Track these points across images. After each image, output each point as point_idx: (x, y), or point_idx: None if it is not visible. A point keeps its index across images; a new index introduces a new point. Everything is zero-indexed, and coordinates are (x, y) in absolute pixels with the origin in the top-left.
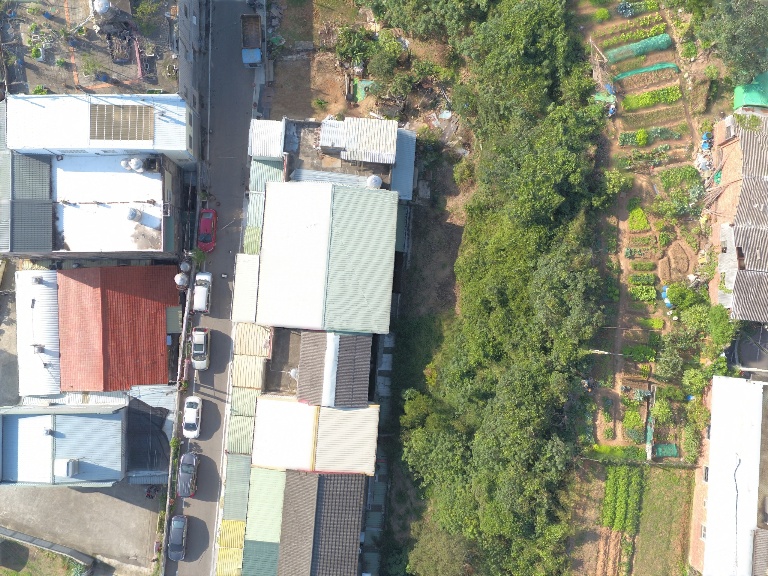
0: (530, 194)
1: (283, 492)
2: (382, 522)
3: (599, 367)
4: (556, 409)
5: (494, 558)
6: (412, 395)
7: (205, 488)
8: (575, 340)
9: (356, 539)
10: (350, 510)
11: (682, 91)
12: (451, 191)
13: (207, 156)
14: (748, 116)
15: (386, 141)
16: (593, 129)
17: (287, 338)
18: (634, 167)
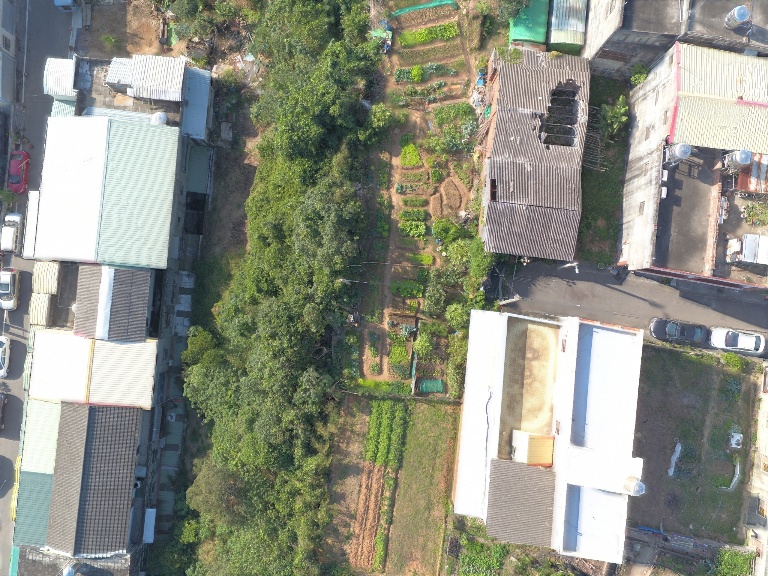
0: (288, 125)
1: (58, 424)
2: (179, 461)
3: (367, 302)
4: (324, 344)
5: (257, 490)
6: (196, 332)
7: (12, 427)
8: (326, 271)
9: (130, 472)
10: (124, 443)
11: (460, 27)
12: (250, 132)
13: (22, 99)
14: (510, 49)
15: (172, 78)
16: (367, 64)
17: (75, 274)
18: (409, 103)
